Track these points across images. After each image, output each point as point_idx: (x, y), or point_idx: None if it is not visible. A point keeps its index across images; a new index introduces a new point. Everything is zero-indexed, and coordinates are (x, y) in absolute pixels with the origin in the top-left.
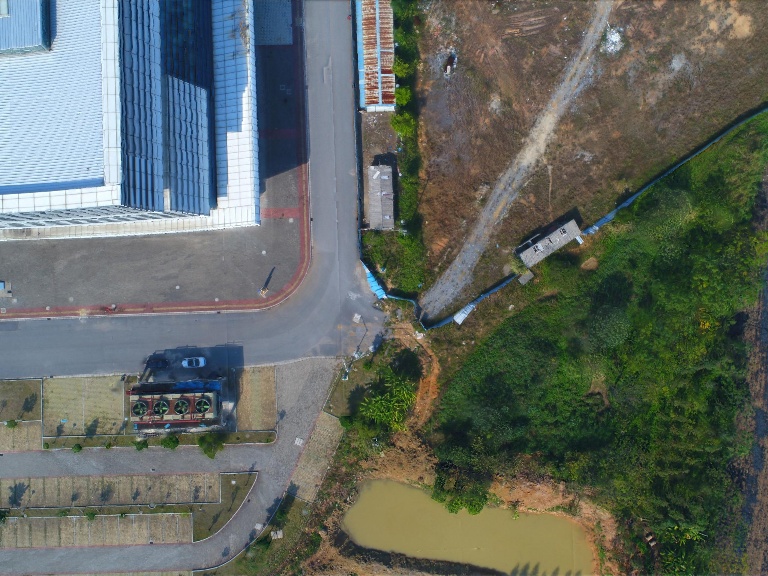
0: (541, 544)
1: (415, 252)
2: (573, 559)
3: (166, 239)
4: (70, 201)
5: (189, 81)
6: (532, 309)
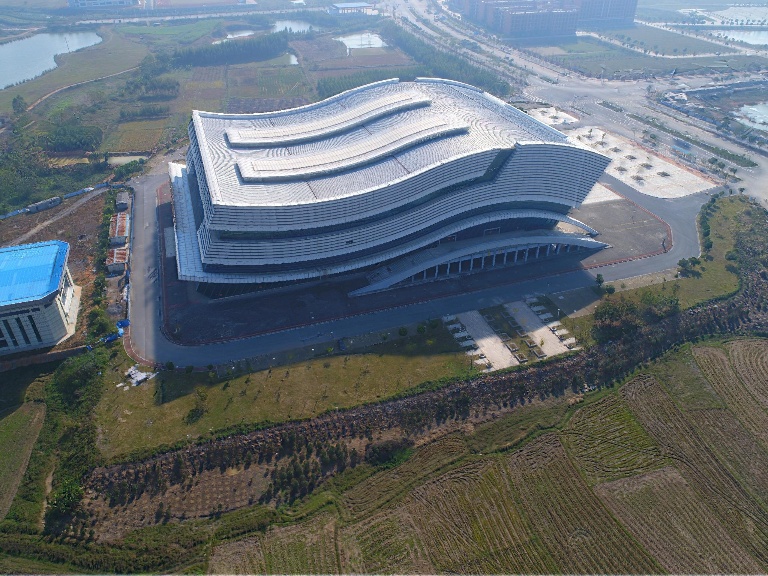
0: None
1: None
2: None
3: None
4: None
5: None
6: None
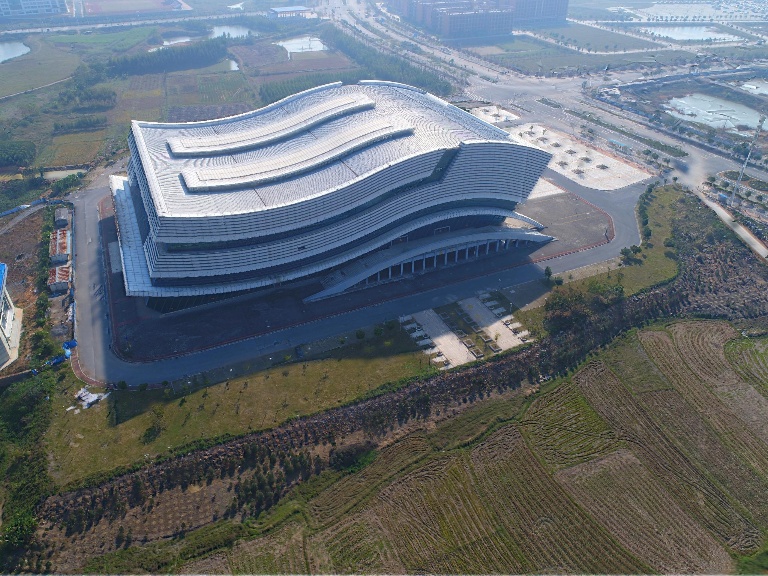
0: None
1: None
2: None
3: None
4: None
5: None
6: None
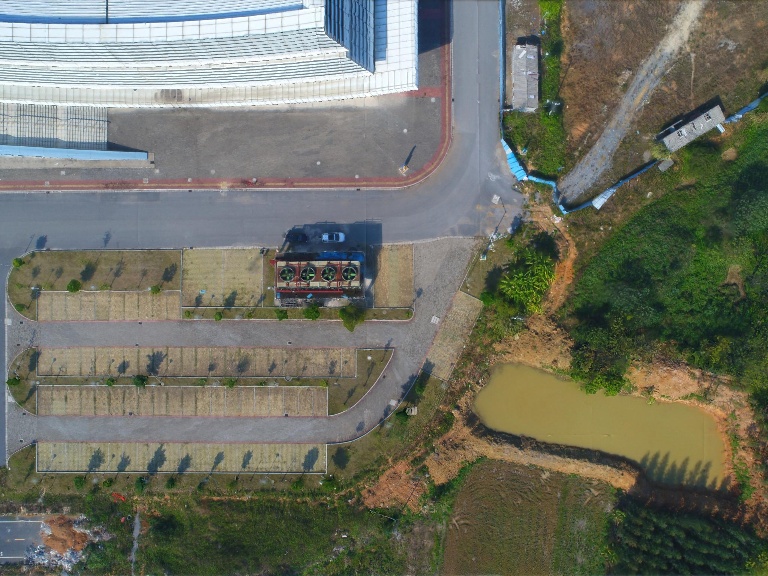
0: (672, 433)
1: (556, 135)
2: (704, 449)
3: (309, 114)
4: (270, 25)
5: None
6: (670, 197)
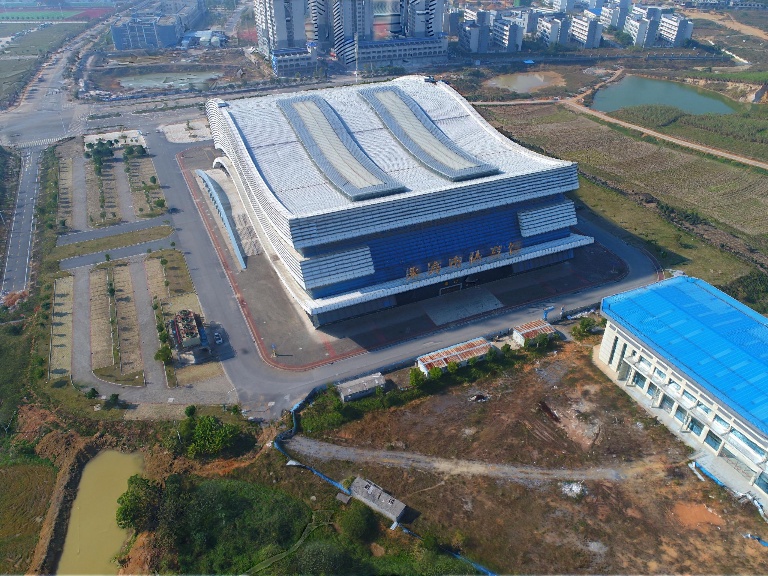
0: None
1: (333, 419)
2: None
3: (292, 310)
4: (285, 213)
5: (376, 266)
6: None
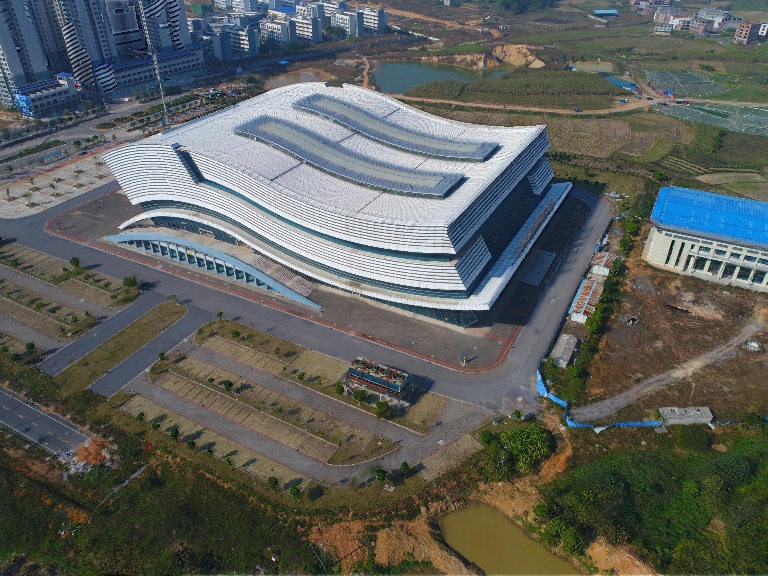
0: None
1: (577, 384)
2: None
3: (421, 323)
4: None
5: None
6: (662, 452)
